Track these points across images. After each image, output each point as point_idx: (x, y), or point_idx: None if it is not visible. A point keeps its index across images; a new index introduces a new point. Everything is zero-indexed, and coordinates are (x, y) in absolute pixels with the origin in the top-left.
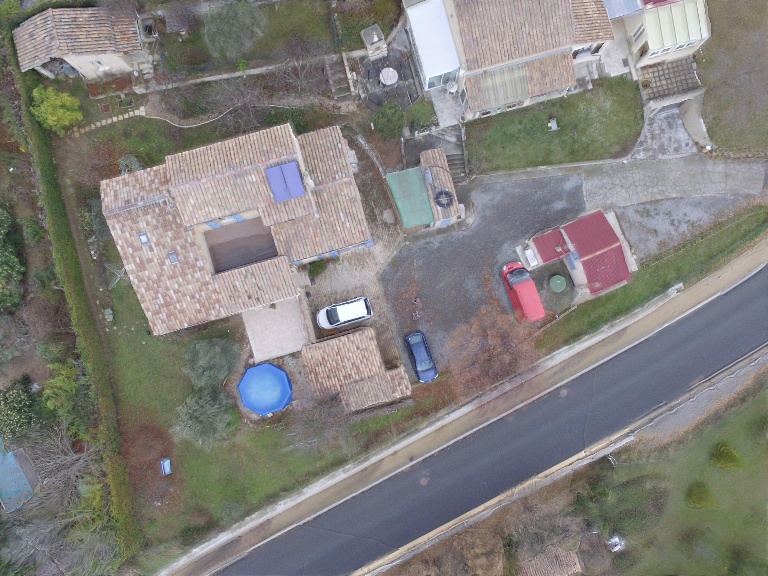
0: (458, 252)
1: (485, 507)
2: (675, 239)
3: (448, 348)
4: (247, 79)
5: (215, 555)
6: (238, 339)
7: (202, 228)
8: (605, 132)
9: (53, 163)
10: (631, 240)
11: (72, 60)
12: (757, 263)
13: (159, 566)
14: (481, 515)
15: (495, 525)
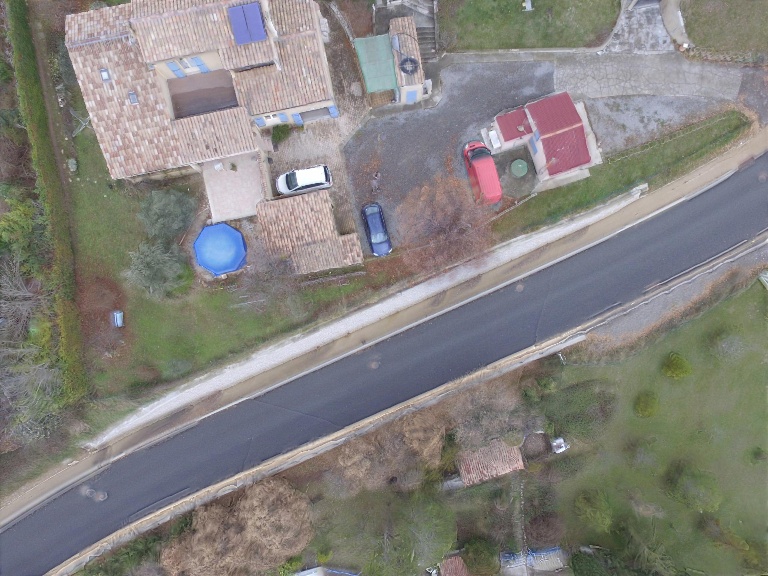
0: (423, 130)
1: (432, 393)
2: (643, 136)
3: (405, 224)
4: None
5: (166, 422)
6: (198, 198)
7: (165, 73)
8: (580, 18)
9: (25, 4)
10: (598, 133)
11: None
12: (725, 170)
13: (109, 423)
14: (428, 400)
15: (442, 415)
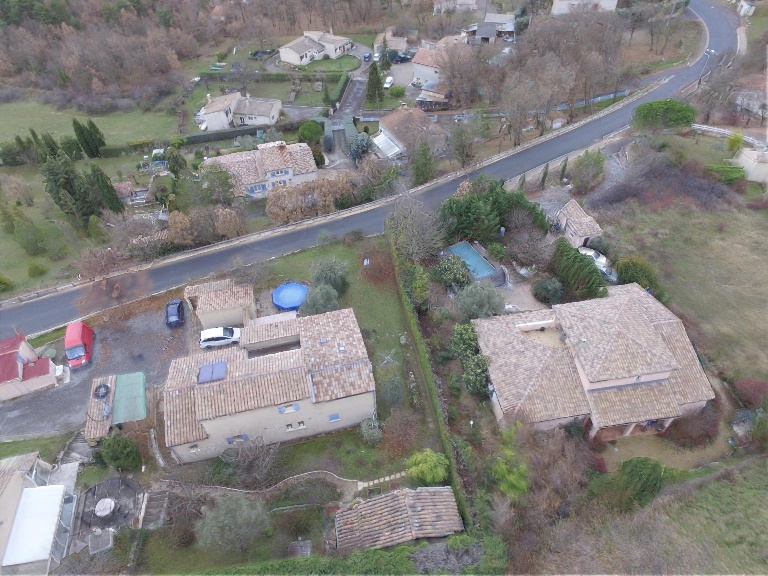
0: None
1: (175, 258)
2: None
3: (154, 319)
4: None
5: None
6: None
7: None
8: None
9: None
10: None
11: None
12: None
13: None
14: None
15: None
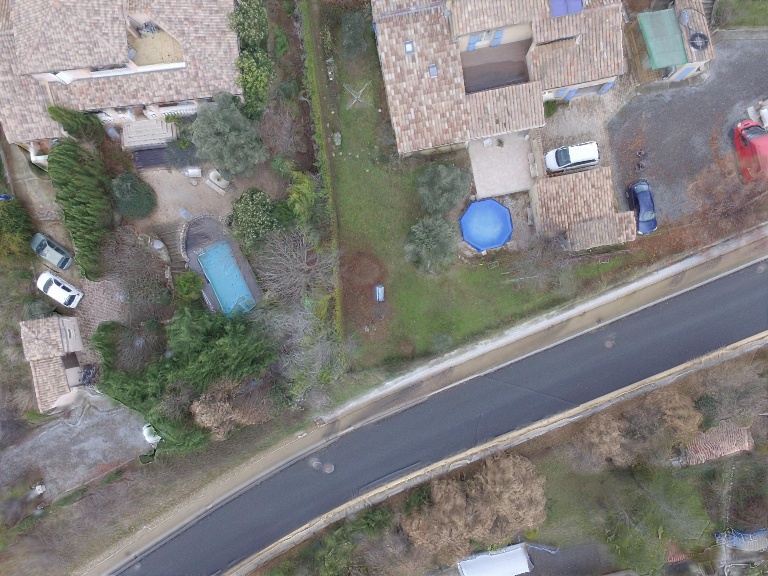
0: (688, 108)
1: (671, 372)
2: None
3: (668, 203)
4: None
5: (395, 397)
6: None
7: (459, 46)
8: None
9: None
10: None
11: None
12: None
13: (350, 397)
14: (666, 380)
15: None
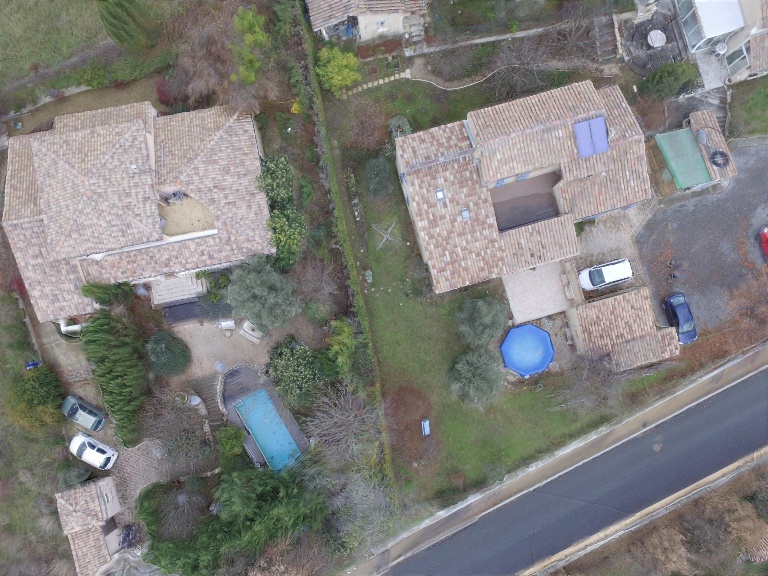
0: (712, 215)
1: (724, 473)
2: None
3: (705, 311)
4: (512, 42)
5: (444, 521)
6: None
7: (488, 186)
8: None
9: None
10: None
11: (365, 19)
12: None
13: (400, 529)
14: (720, 481)
15: (726, 492)
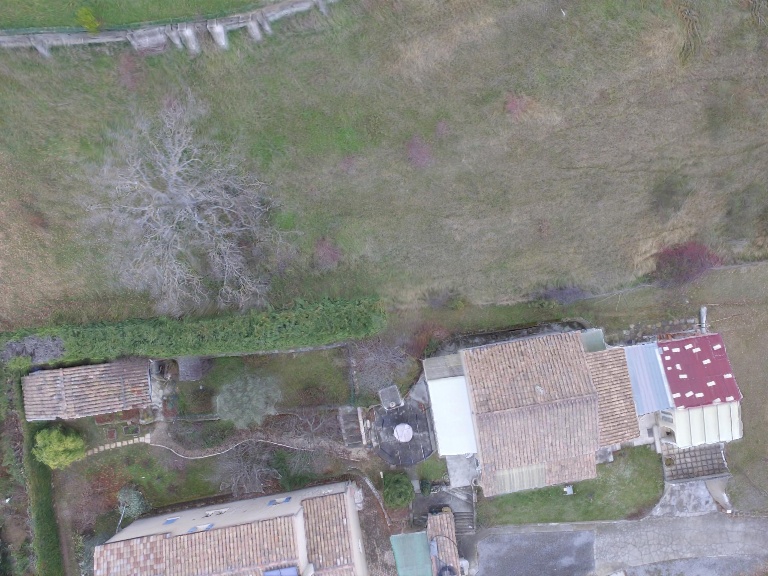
0: None
1: None
2: None
3: None
4: None
5: None
6: None
7: None
8: (622, 498)
9: (51, 489)
10: None
11: None
12: None
13: None
14: None
15: None
